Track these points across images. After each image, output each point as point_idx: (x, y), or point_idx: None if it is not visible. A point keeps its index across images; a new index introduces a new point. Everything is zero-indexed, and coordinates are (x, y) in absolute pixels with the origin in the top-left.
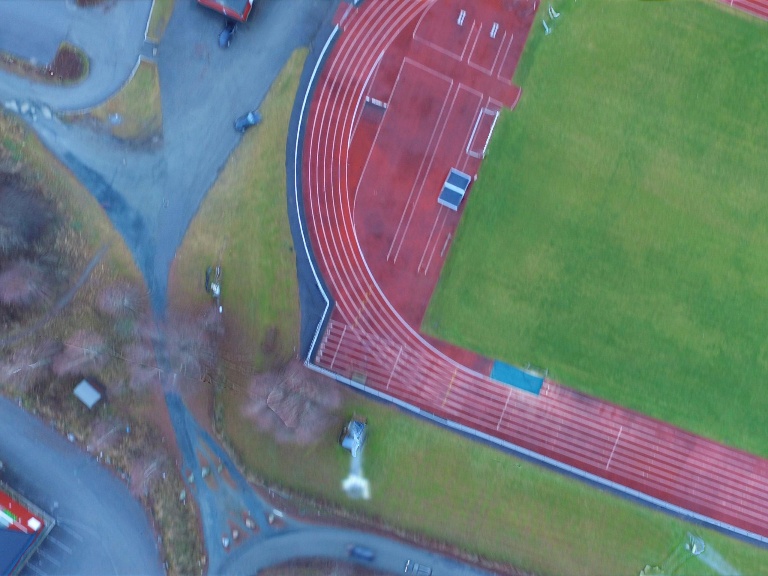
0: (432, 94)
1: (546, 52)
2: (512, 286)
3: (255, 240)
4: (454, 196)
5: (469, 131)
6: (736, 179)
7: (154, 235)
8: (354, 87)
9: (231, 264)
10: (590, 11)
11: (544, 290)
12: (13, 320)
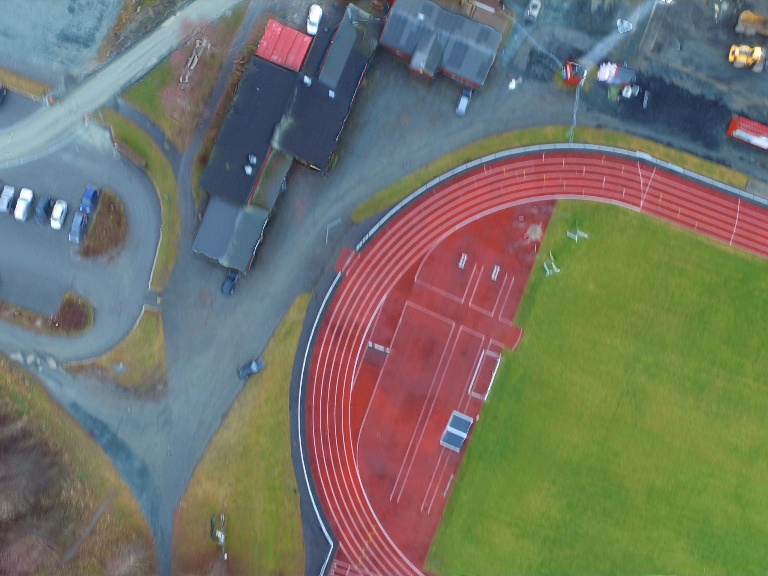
0: (434, 337)
1: (547, 293)
2: (514, 524)
3: (259, 486)
4: (456, 439)
5: (471, 372)
6: (736, 416)
7: (159, 483)
8: (357, 331)
9: (236, 510)
10: (590, 252)
11: (546, 527)
12: (20, 575)
